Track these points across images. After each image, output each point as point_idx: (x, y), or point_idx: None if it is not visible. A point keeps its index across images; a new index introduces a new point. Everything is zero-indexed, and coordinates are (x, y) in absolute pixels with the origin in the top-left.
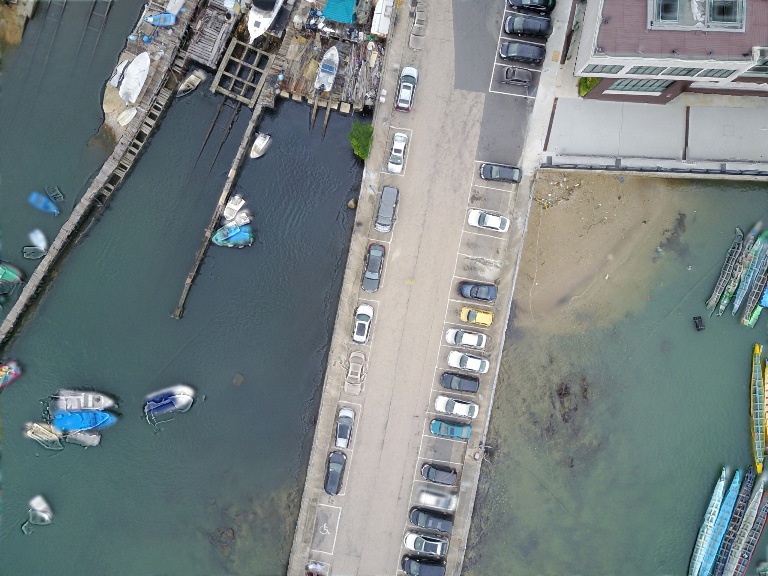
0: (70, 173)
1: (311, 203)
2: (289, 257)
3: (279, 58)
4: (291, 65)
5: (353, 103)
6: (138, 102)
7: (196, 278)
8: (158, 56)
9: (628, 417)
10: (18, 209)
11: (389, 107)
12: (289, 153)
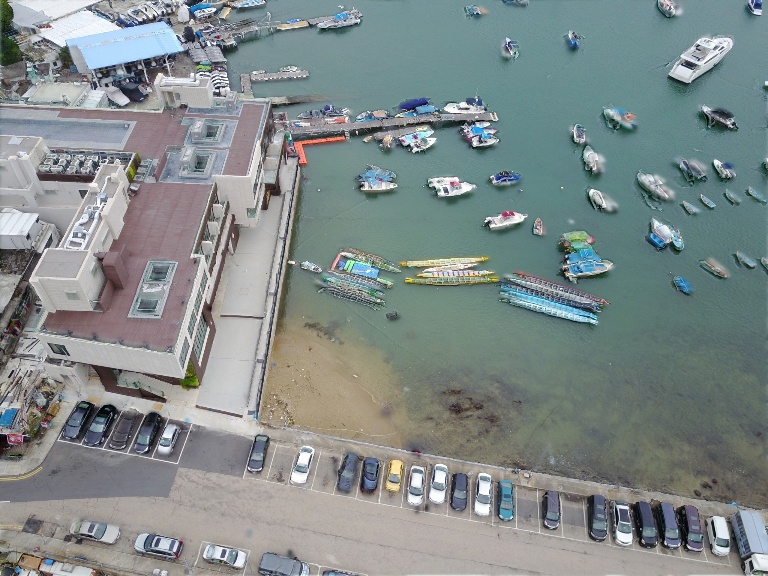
0: None
1: None
2: None
3: None
4: None
5: None
6: None
7: None
8: None
9: (471, 362)
10: None
11: (173, 567)
12: None
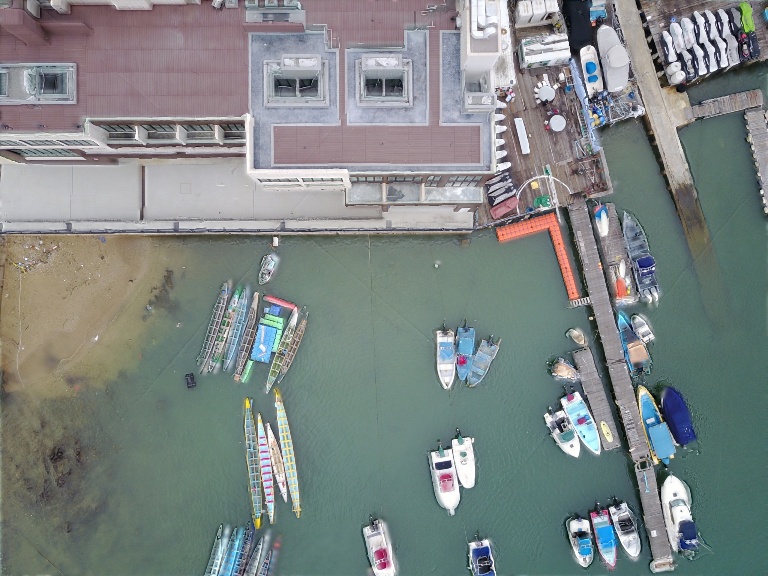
0: None
1: None
2: None
3: None
4: None
5: None
6: None
7: None
8: None
9: (126, 478)
10: None
11: None
12: None
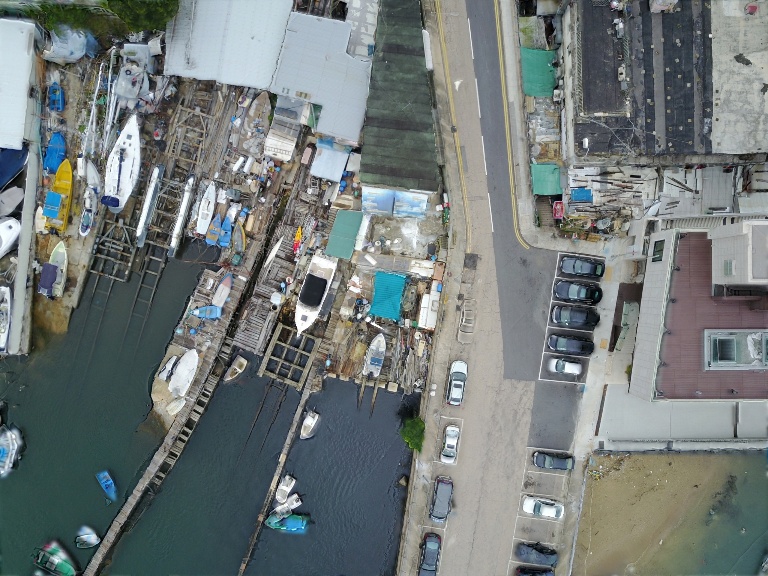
0: (120, 458)
1: (360, 473)
2: (341, 533)
3: (325, 342)
4: (337, 348)
5: (401, 383)
6: (187, 393)
7: (250, 562)
8: (205, 347)
9: None
10: (69, 498)
11: (439, 398)
12: (337, 429)
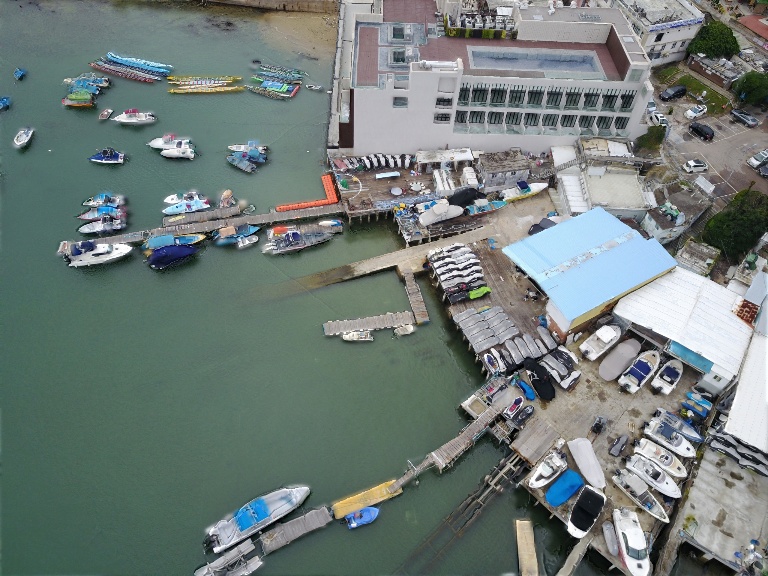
0: None
1: None
2: None
3: None
4: None
5: None
6: None
7: None
8: None
9: None
10: None
11: None
12: None
